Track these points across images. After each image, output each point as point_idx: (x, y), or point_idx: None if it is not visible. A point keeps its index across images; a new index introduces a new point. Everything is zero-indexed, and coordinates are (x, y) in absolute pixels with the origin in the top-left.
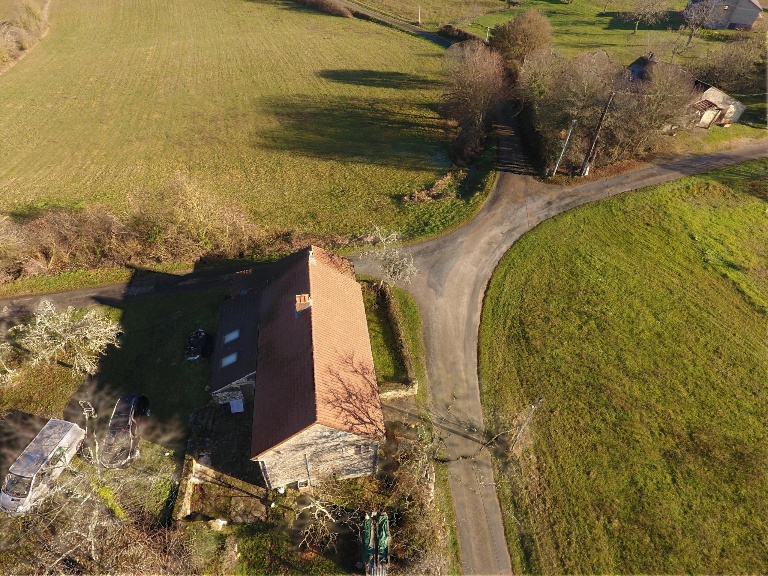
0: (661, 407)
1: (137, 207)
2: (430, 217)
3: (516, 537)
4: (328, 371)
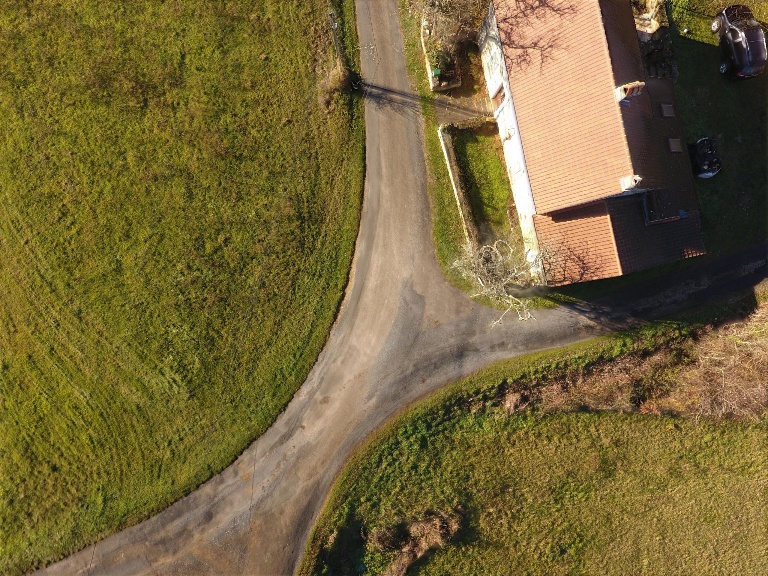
0: (165, 135)
1: None
2: (417, 461)
3: (345, 6)
4: (576, 7)
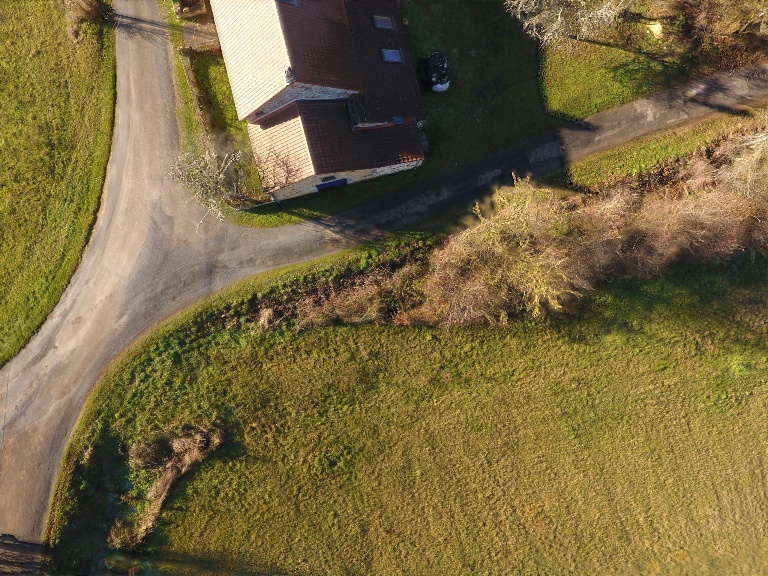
0: None
1: (599, 219)
2: (171, 377)
3: None
4: None
